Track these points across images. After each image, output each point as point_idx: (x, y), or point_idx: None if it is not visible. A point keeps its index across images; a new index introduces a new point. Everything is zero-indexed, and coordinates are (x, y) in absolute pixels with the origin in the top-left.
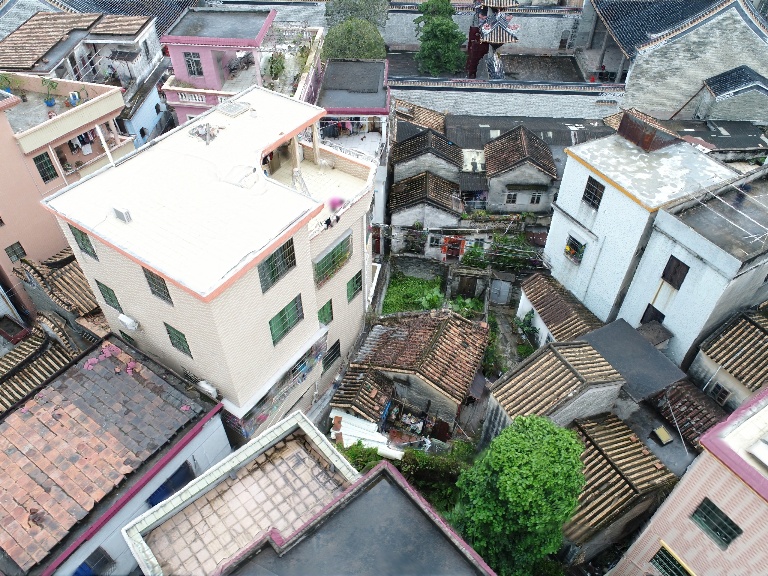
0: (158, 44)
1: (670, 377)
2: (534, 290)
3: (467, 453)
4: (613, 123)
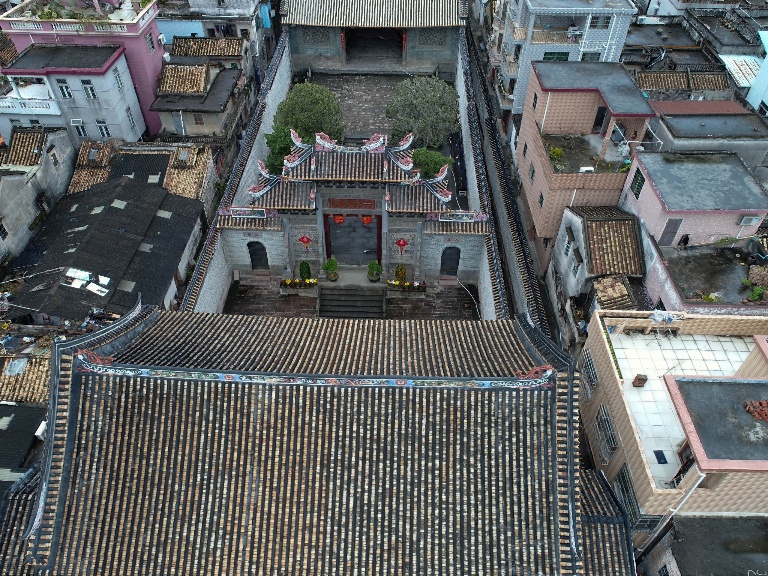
0: (246, 4)
1: None
2: None
3: None
4: None
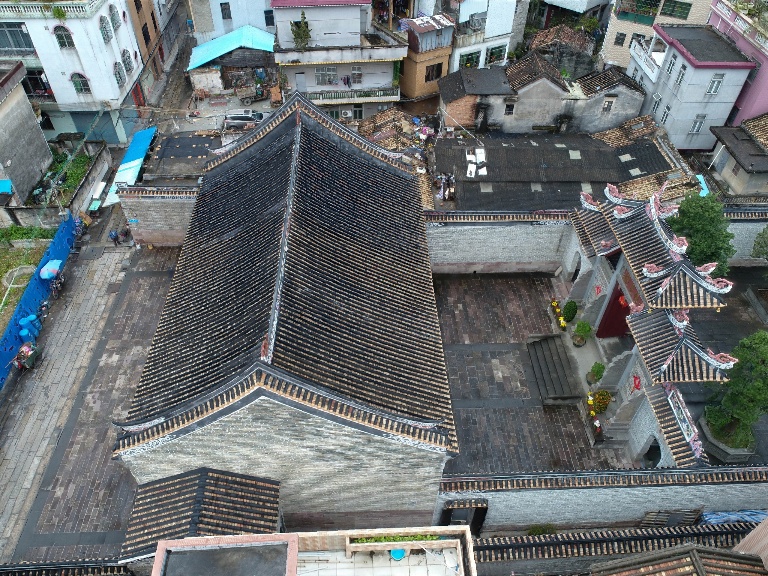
0: None
1: None
2: None
3: (527, 39)
4: (426, 195)
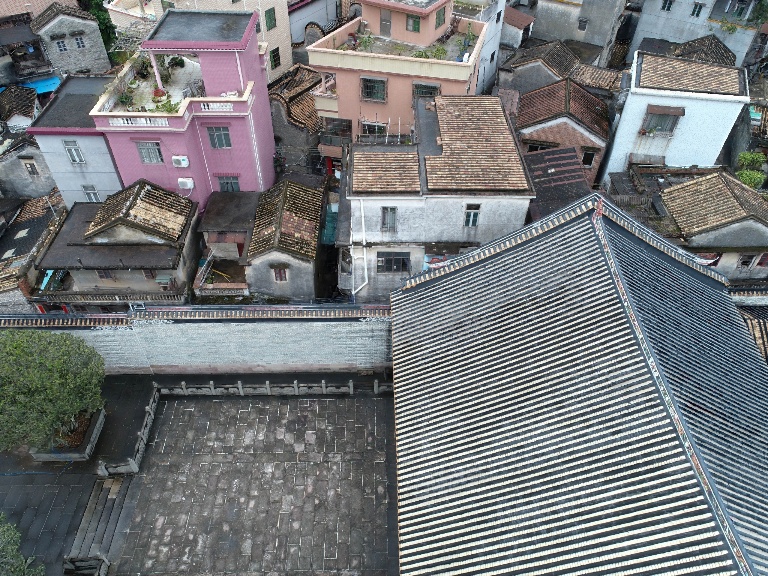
0: None
1: (5, 29)
2: (26, 111)
3: None
4: None
